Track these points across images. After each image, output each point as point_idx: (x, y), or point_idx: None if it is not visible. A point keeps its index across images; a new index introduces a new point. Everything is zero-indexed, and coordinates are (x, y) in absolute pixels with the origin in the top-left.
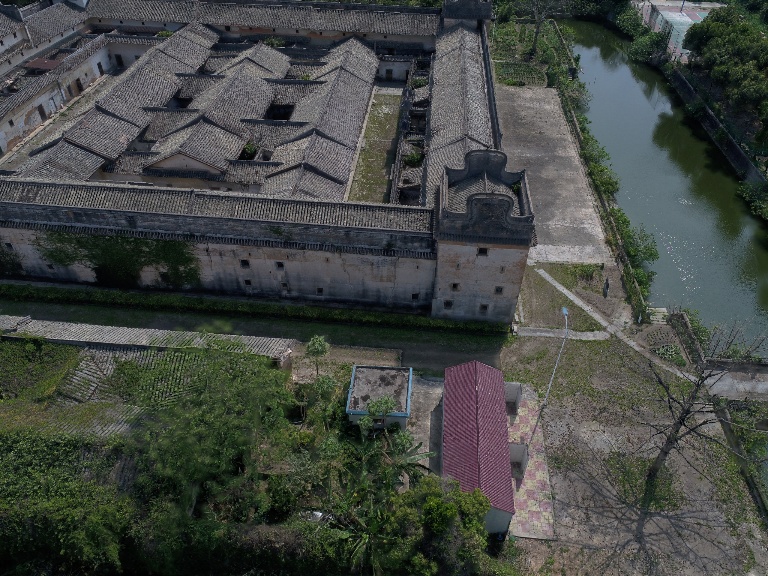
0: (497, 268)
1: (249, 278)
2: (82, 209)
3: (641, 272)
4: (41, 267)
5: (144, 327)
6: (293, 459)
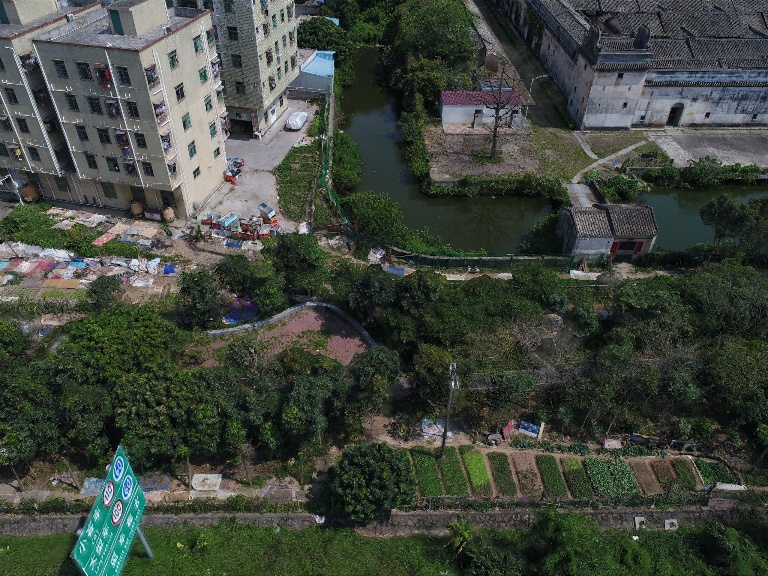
0: None
1: (547, 57)
2: None
3: (673, 169)
4: None
5: None
6: (443, 61)
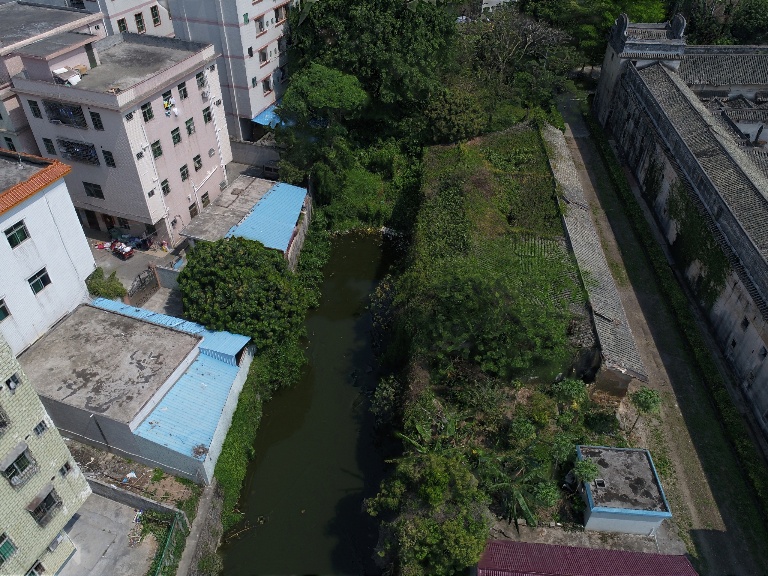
0: None
1: (737, 340)
2: (707, 179)
3: None
4: (662, 207)
5: (637, 290)
6: (494, 389)
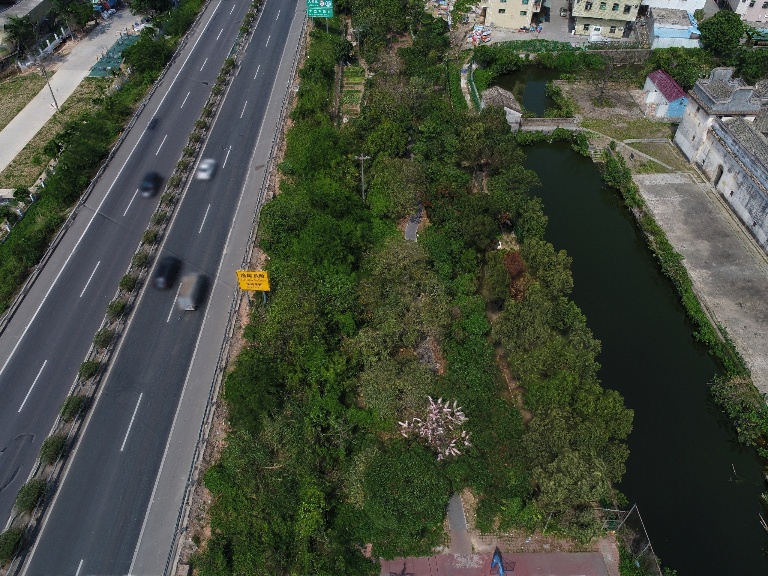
0: None
1: None
2: None
3: (615, 163)
4: None
5: None
6: None
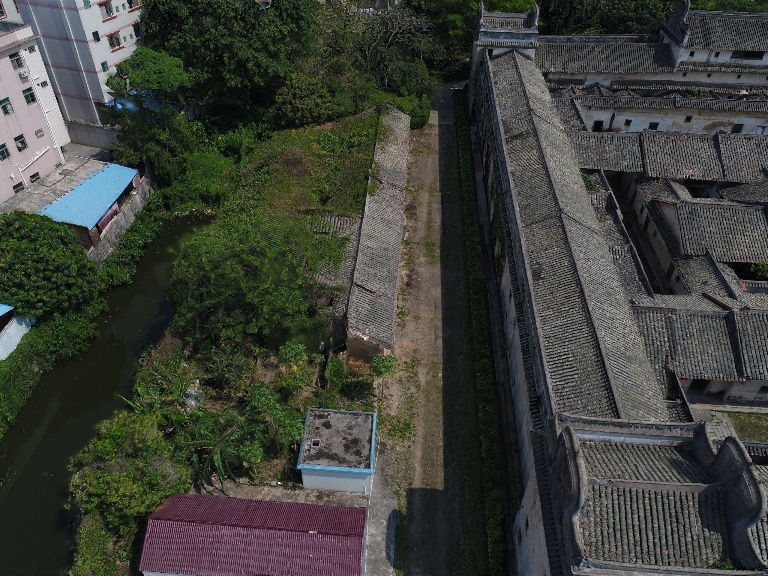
0: (544, 566)
1: None
2: None
3: None
4: None
5: (443, 267)
6: (235, 355)
